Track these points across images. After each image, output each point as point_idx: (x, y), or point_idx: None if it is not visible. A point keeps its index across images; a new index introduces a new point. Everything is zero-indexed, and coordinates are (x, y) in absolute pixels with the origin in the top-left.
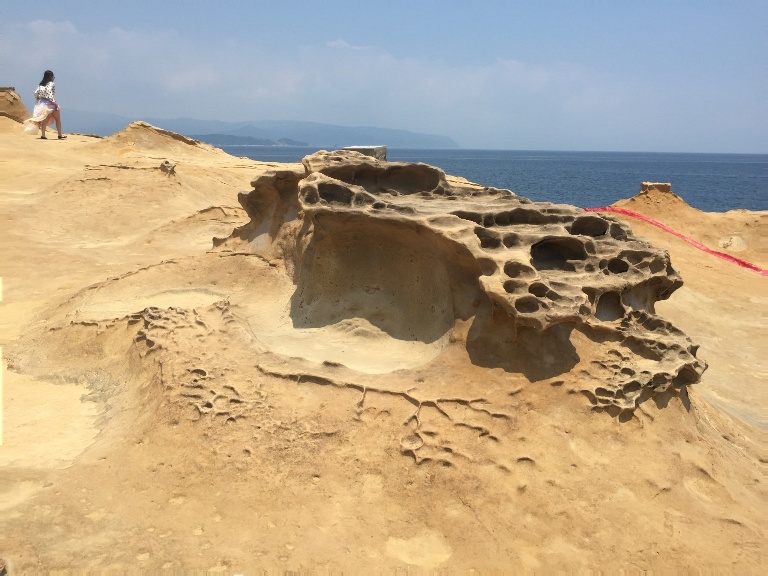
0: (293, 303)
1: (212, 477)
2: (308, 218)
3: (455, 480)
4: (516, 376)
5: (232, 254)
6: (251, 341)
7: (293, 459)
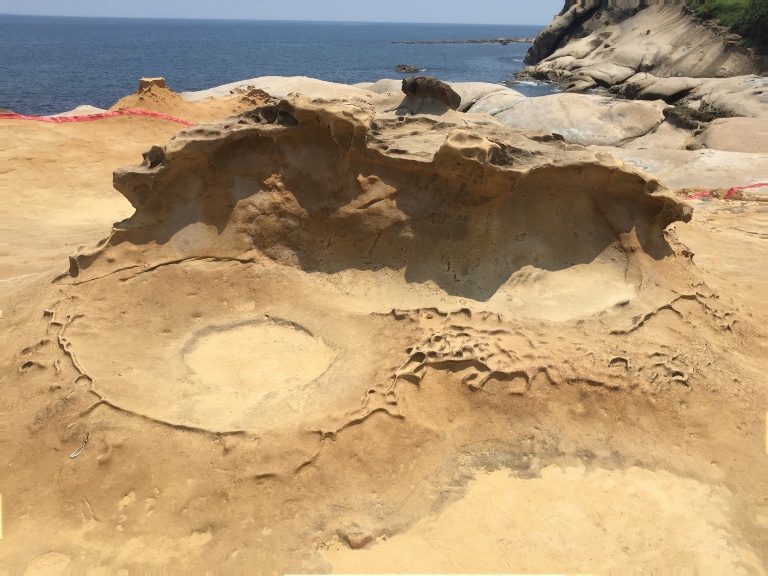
0: (440, 281)
1: (760, 408)
2: (297, 186)
3: (746, 328)
4: (673, 257)
5: (147, 269)
6: None
7: (734, 369)
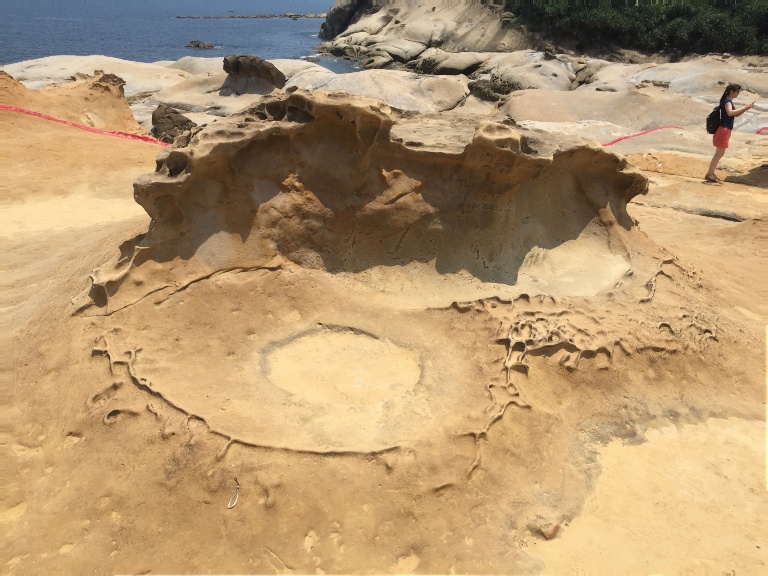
0: (472, 270)
1: (766, 351)
2: (317, 185)
3: None
4: None
5: (180, 289)
6: (590, 297)
7: None
